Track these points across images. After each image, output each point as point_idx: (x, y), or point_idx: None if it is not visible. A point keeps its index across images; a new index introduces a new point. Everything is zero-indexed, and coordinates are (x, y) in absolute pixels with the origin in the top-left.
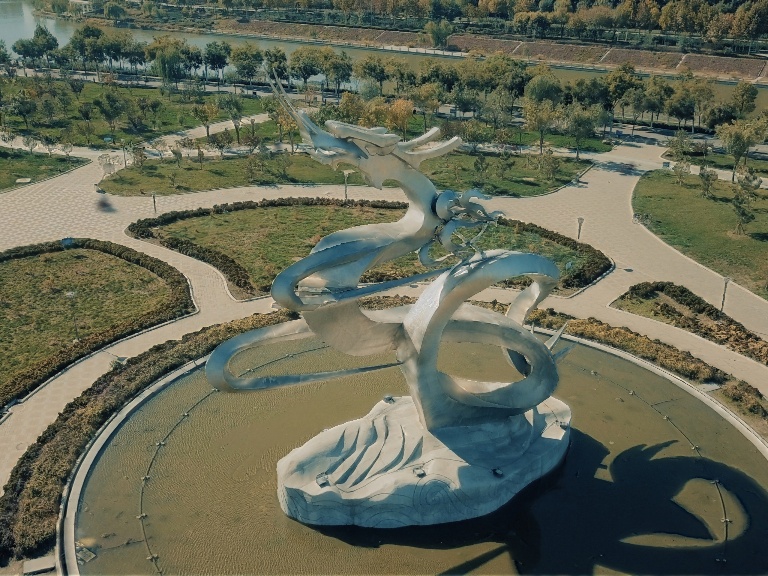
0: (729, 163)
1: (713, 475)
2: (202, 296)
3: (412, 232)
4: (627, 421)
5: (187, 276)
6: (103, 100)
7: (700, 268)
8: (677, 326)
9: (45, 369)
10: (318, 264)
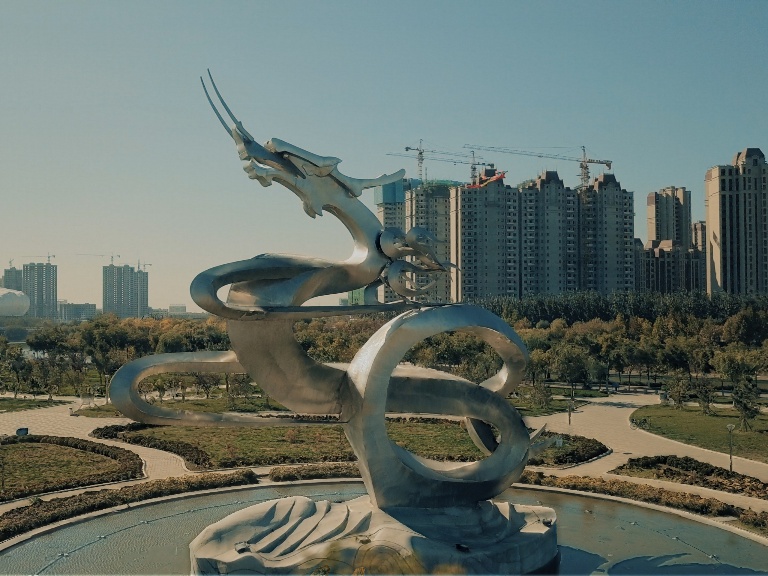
0: (730, 400)
1: (737, 575)
2: (154, 470)
3: (354, 263)
4: (628, 541)
5: (143, 459)
6: (96, 350)
7: (706, 452)
8: (683, 483)
9: None
10: (245, 269)
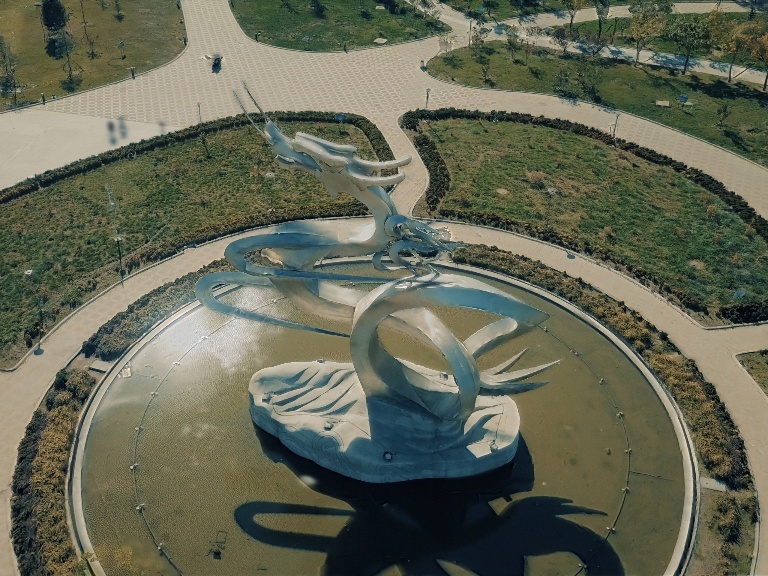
0: None
1: (591, 560)
2: None
3: (360, 240)
4: (586, 473)
5: None
6: None
7: None
8: None
9: (229, 227)
10: (263, 244)
